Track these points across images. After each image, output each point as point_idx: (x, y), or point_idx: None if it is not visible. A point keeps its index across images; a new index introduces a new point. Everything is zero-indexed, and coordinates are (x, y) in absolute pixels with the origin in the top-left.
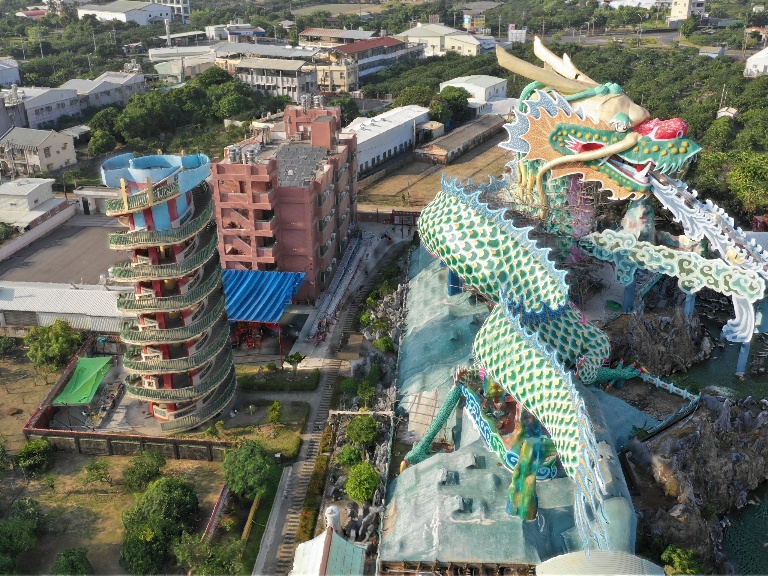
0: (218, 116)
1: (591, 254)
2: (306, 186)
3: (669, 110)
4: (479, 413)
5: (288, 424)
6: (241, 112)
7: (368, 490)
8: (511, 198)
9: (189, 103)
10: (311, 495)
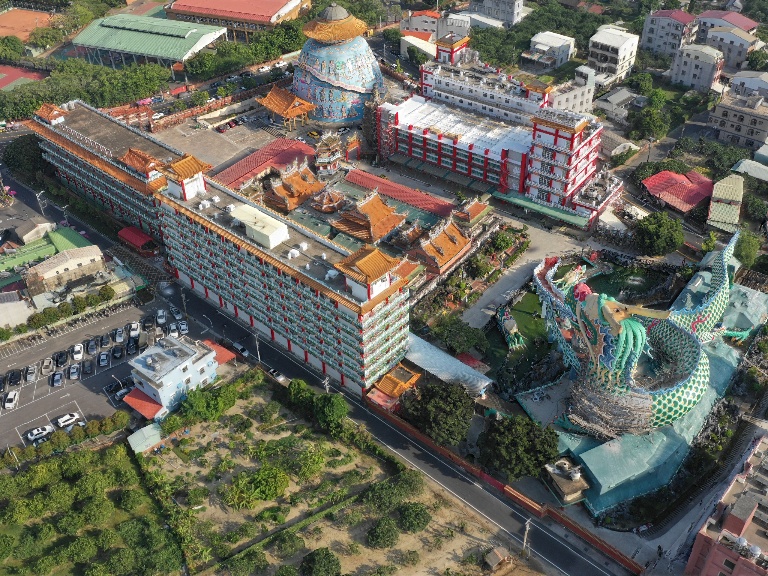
0: None
1: None
2: None
3: None
4: None
5: None
6: None
7: None
8: None
9: None
10: None
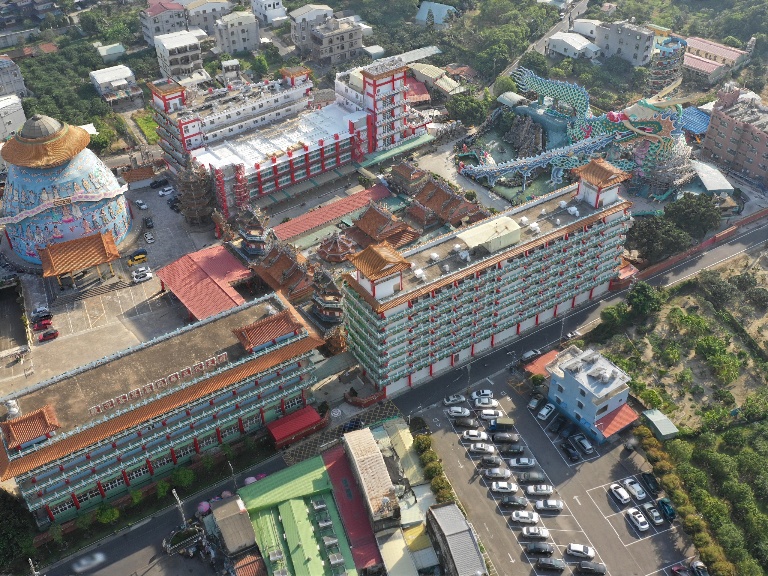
0: None
1: None
2: (719, 110)
3: None
4: None
5: None
6: None
7: None
8: None
9: None
10: None
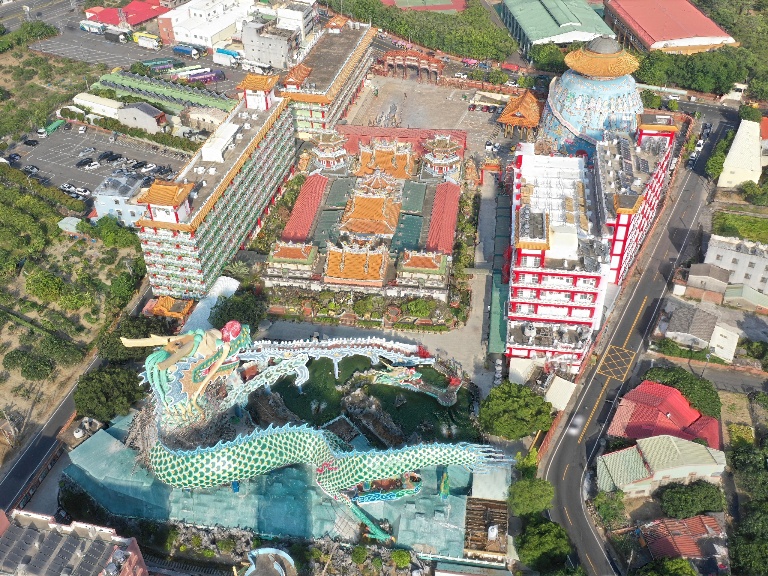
0: None
1: (226, 410)
2: None
3: None
4: (380, 495)
5: None
6: None
7: None
8: (175, 425)
9: None
10: None
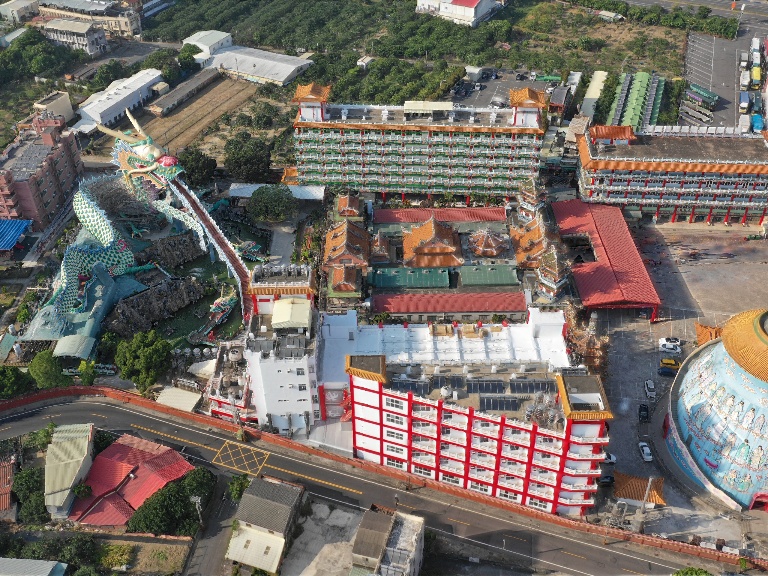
0: (32, 72)
1: (157, 209)
2: (28, 180)
3: (331, 58)
4: None
5: (12, 293)
6: (46, 69)
7: (24, 319)
8: (124, 182)
9: (11, 63)
10: (11, 321)
